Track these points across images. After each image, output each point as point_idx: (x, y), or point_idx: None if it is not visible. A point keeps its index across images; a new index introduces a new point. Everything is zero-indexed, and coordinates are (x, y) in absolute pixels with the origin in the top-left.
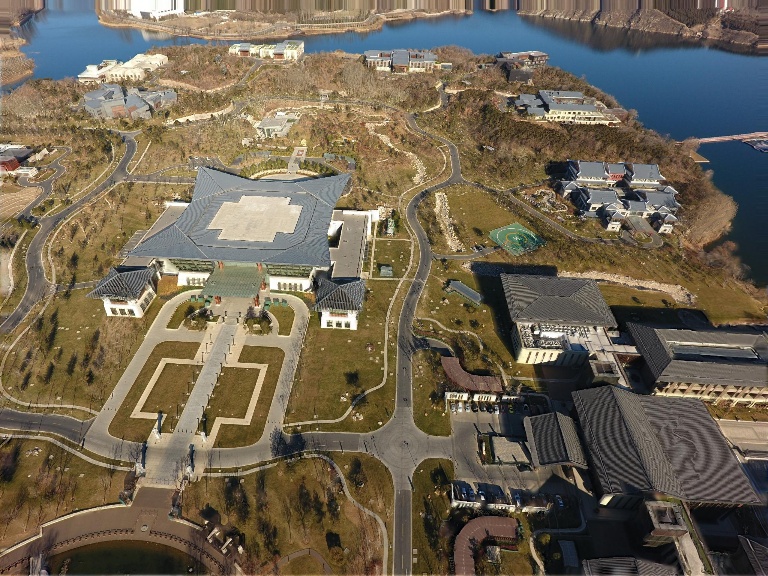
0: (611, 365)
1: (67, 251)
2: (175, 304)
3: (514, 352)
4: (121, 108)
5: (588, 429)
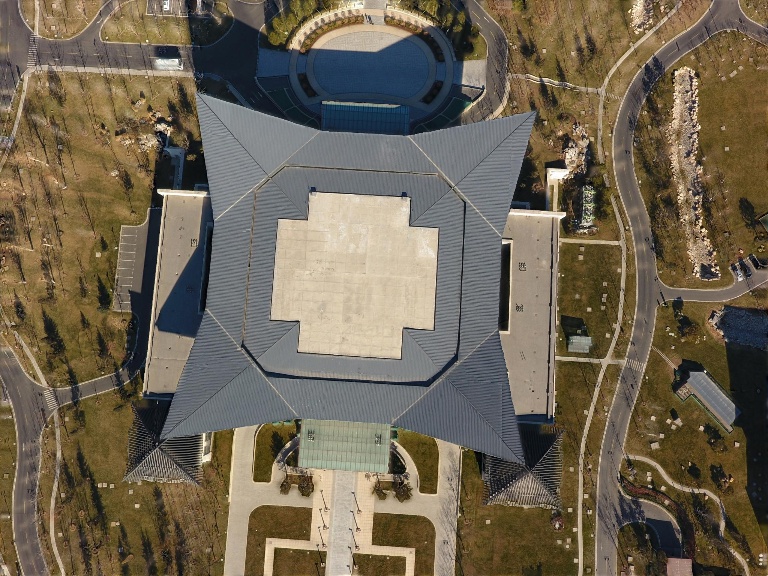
0: None
1: (29, 307)
2: (250, 428)
3: None
4: None
5: None
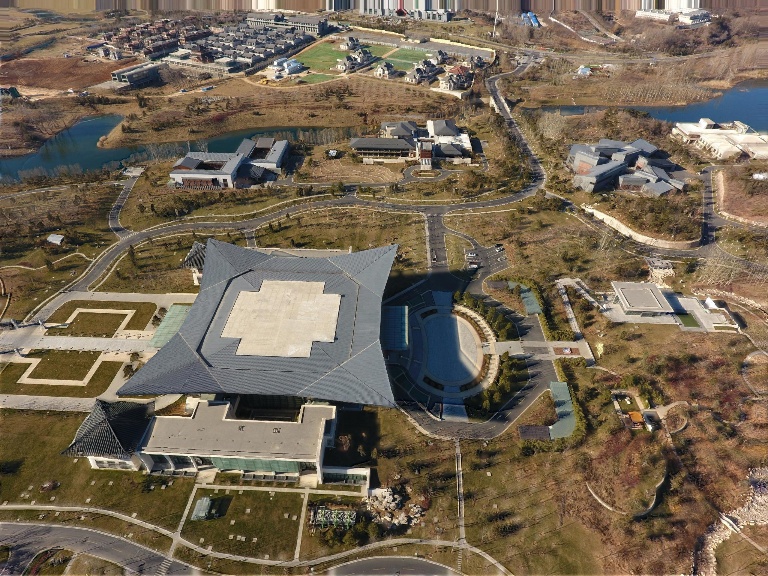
0: None
1: None
2: None
3: None
4: (589, 167)
5: None
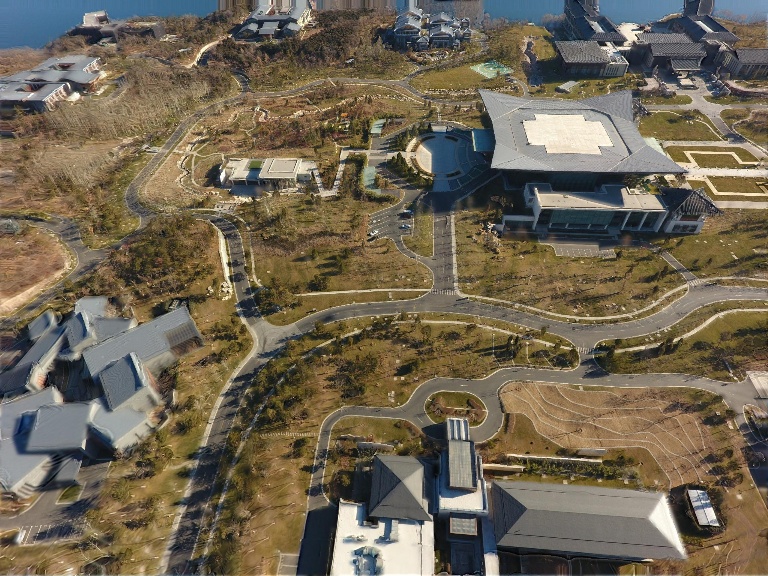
0: (638, 40)
1: (637, 290)
2: None
3: (617, 76)
4: None
5: (675, 54)
